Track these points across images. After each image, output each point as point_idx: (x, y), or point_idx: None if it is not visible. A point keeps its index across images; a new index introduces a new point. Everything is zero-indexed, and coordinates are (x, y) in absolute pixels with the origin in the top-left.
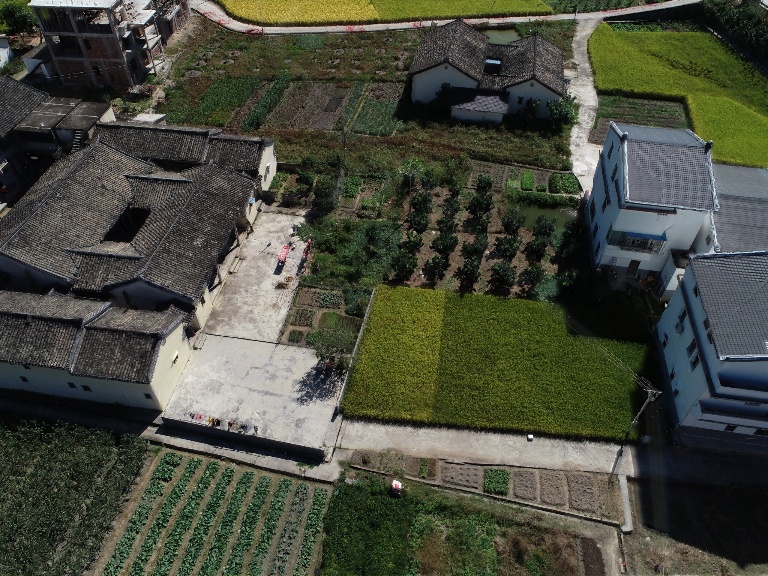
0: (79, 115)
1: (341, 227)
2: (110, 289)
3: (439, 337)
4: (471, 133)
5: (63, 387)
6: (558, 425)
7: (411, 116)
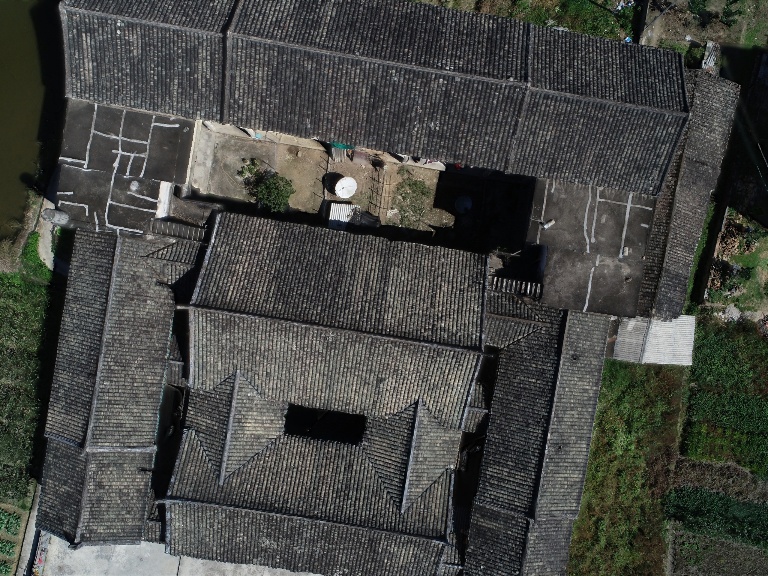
0: (593, 273)
1: None
2: None
3: None
4: None
5: None
6: None
7: None
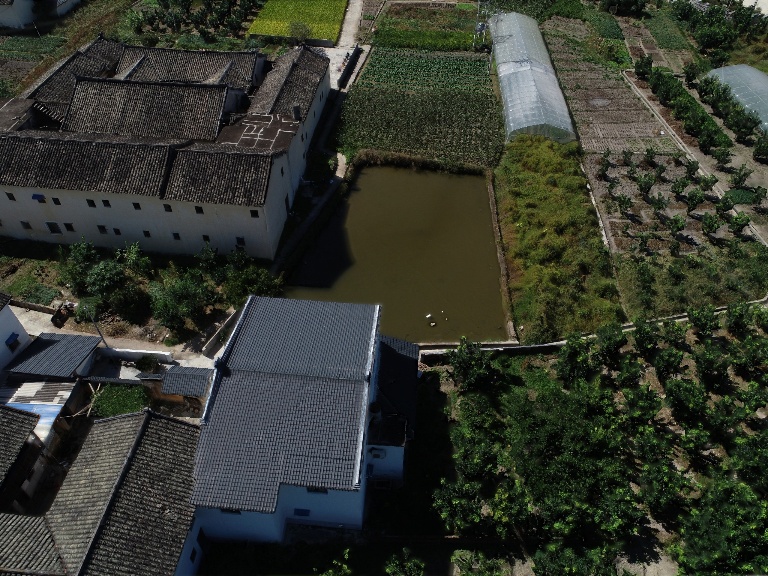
0: (1, 109)
1: (183, 48)
2: (252, 79)
3: (289, 22)
4: (87, 12)
5: (319, 105)
6: (343, 3)
7: (45, 30)
